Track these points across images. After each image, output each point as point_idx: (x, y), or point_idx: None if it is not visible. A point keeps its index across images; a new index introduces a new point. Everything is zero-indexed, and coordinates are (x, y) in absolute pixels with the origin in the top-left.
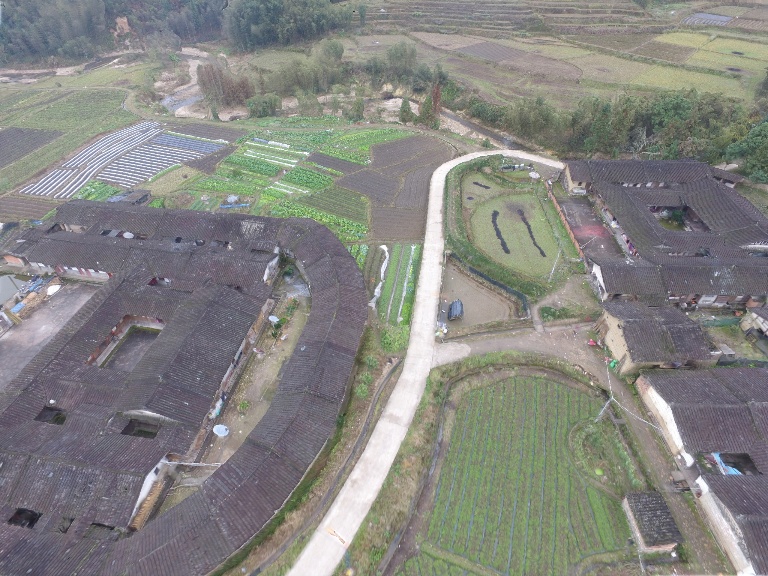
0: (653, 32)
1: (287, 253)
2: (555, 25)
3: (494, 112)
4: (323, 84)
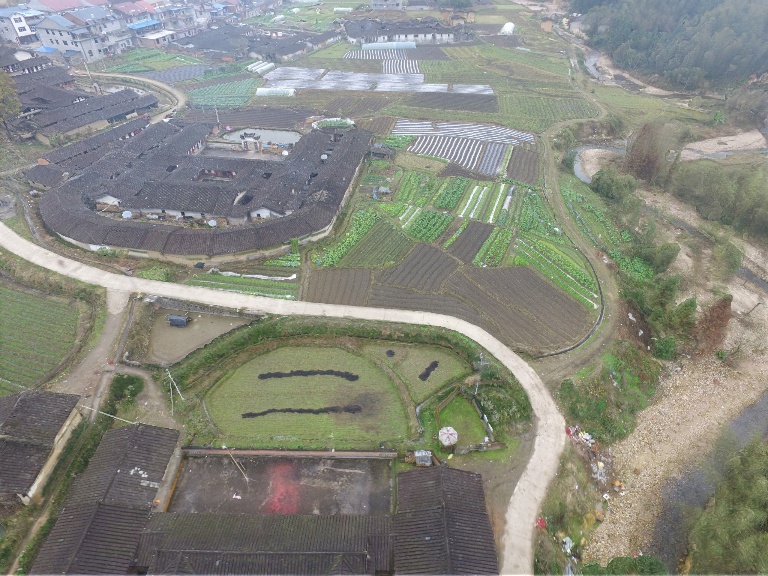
0: None
1: None
2: None
3: None
4: None
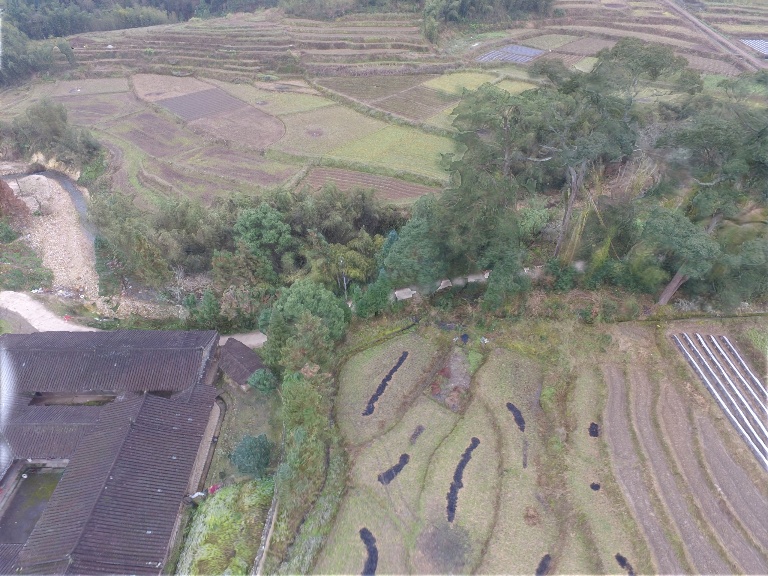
0: (433, 72)
1: None
2: (311, 65)
3: None
4: None
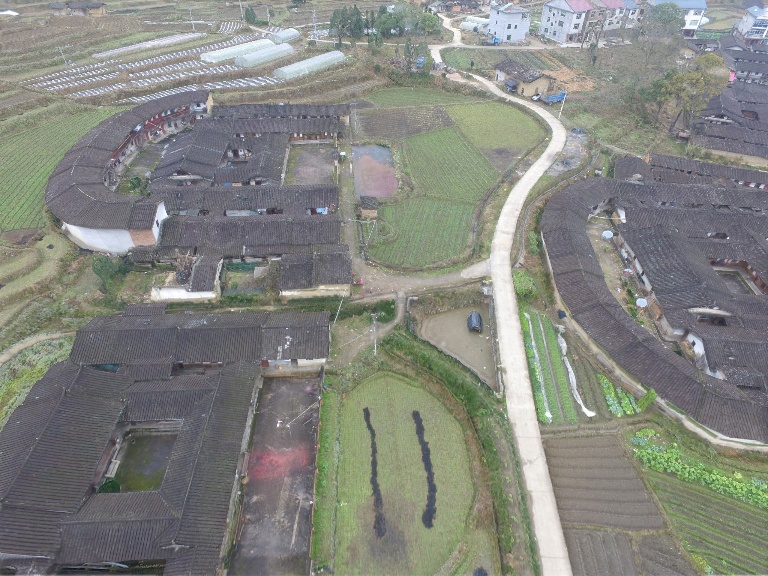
0: None
1: None
2: None
3: None
4: None
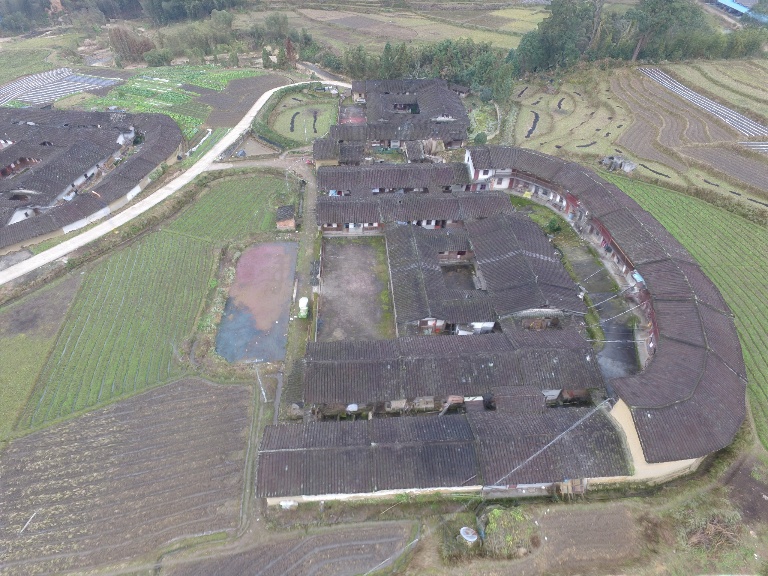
0: (493, 9)
1: (141, 133)
2: (414, 3)
3: (338, 61)
4: (210, 43)
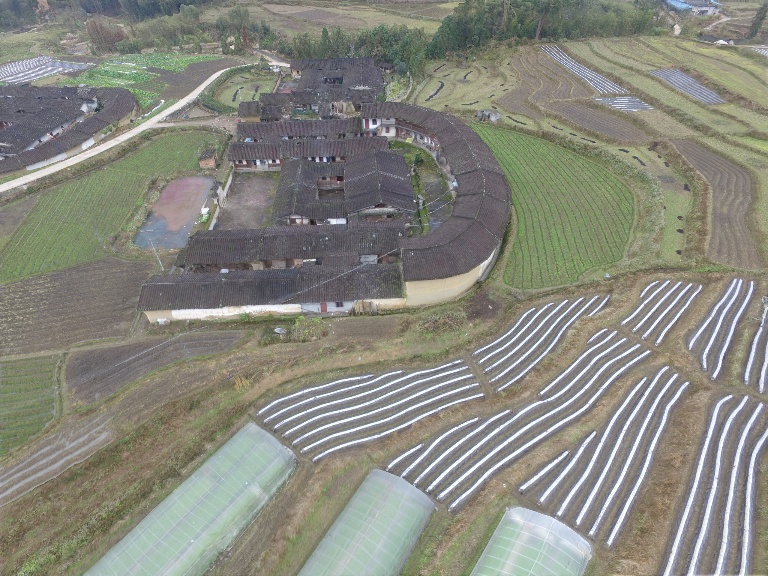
0: (442, 2)
1: None
2: None
3: (290, 48)
4: (177, 34)
